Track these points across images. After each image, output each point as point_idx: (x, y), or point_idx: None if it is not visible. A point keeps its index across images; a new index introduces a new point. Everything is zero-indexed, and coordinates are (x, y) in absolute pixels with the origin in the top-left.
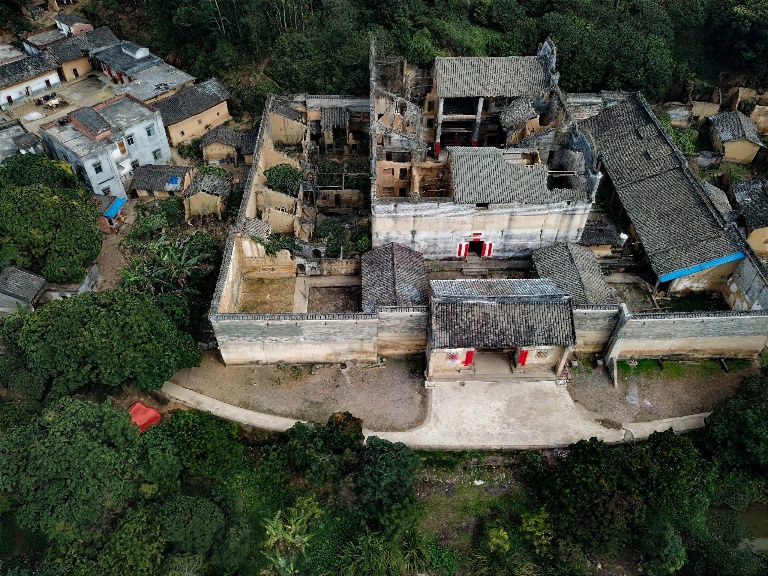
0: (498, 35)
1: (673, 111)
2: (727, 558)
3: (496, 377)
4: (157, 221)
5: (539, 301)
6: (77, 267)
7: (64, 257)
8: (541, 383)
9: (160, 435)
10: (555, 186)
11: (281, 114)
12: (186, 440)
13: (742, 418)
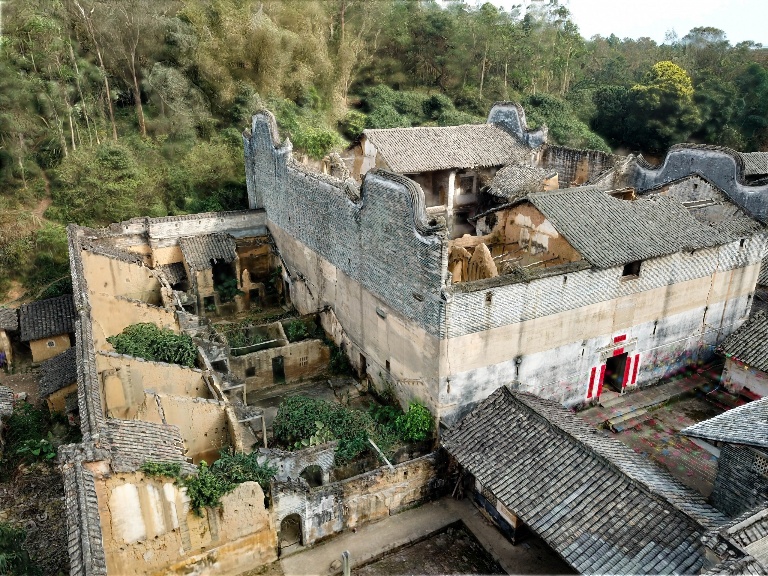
0: None
1: None
2: None
3: None
4: None
5: None
6: None
7: None
8: None
9: None
10: None
11: (104, 254)
12: None
13: None
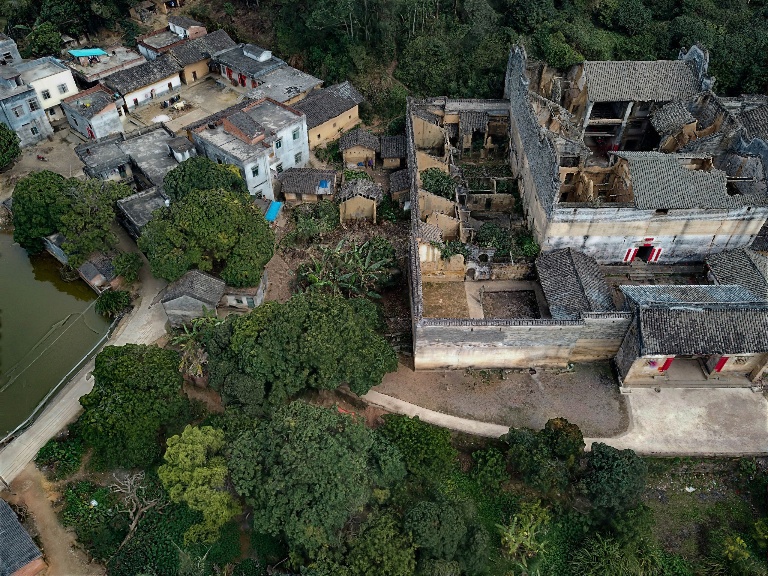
0: (623, 38)
1: None
2: None
3: (691, 383)
4: (322, 225)
5: (746, 308)
6: (257, 271)
7: (245, 261)
8: (737, 390)
9: (383, 440)
10: None
11: (422, 118)
12: (412, 446)
13: None
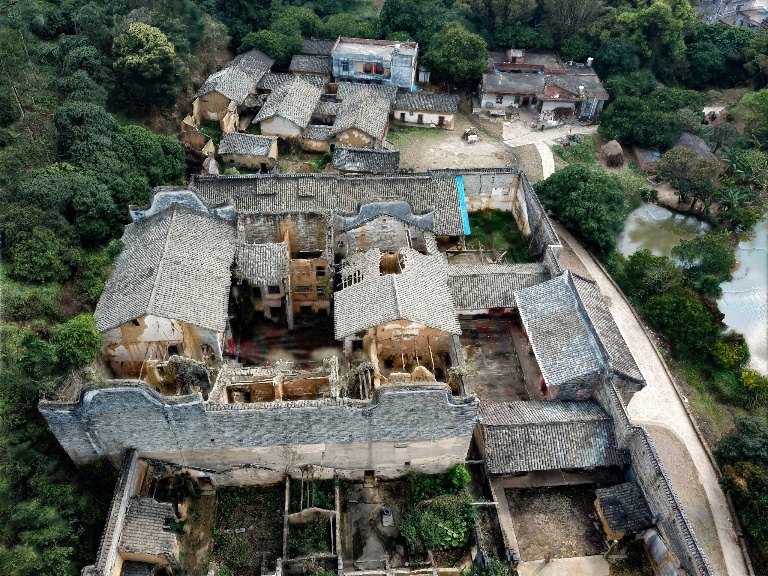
0: None
1: (209, 169)
2: (715, 256)
3: None
4: None
5: None
6: None
7: None
8: None
9: None
10: None
11: None
12: None
13: (611, 222)
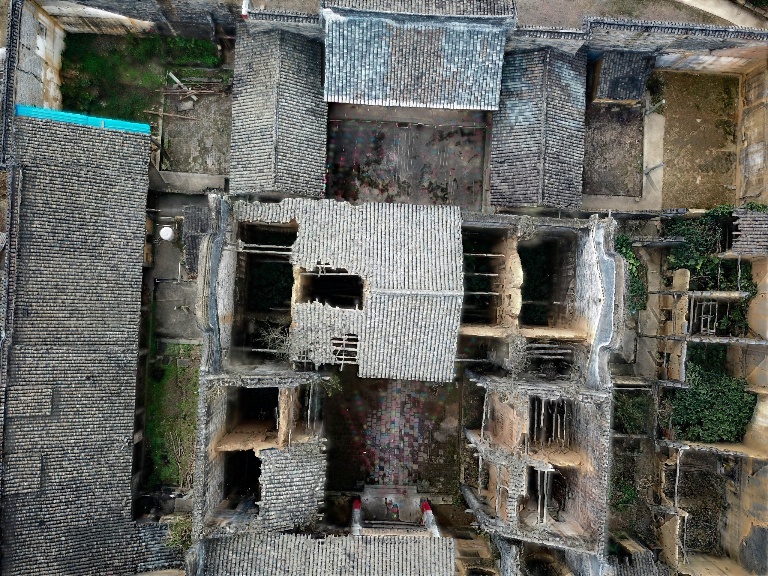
0: None
1: None
2: None
3: None
4: None
5: None
6: None
7: None
8: None
9: None
10: (244, 353)
11: None
12: None
13: None
